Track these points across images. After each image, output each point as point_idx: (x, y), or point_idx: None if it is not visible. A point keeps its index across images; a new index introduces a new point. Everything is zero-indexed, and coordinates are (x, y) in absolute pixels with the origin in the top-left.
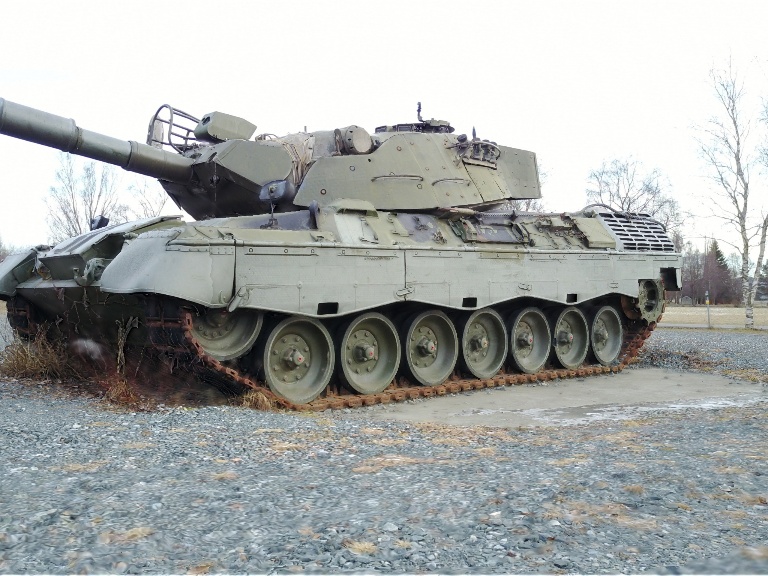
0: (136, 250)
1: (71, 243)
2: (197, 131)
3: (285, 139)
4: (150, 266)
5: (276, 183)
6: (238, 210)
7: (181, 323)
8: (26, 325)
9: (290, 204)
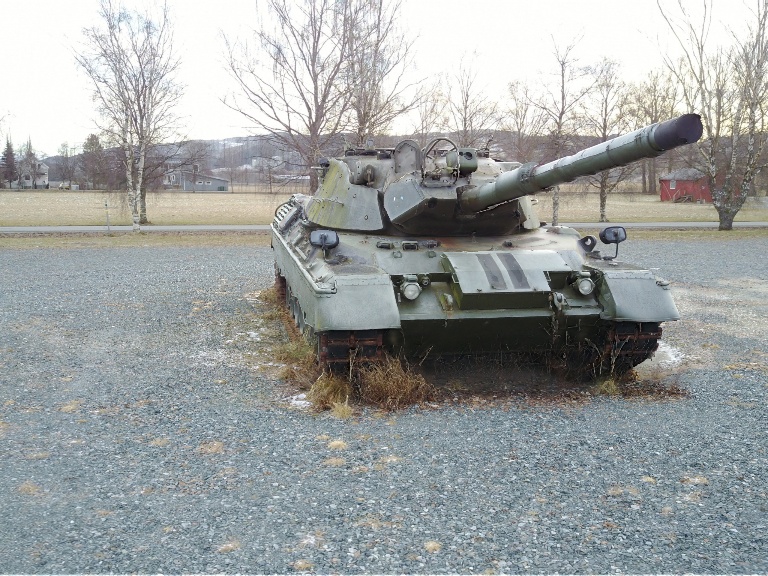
0: (633, 289)
1: (491, 278)
2: (463, 164)
3: (485, 170)
4: (666, 302)
5: (616, 229)
6: (481, 230)
7: (657, 335)
8: (374, 354)
9: (522, 227)
